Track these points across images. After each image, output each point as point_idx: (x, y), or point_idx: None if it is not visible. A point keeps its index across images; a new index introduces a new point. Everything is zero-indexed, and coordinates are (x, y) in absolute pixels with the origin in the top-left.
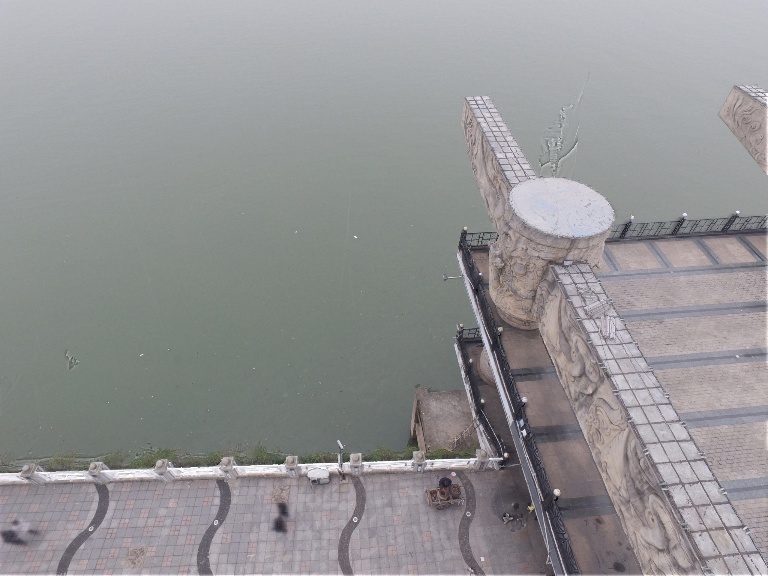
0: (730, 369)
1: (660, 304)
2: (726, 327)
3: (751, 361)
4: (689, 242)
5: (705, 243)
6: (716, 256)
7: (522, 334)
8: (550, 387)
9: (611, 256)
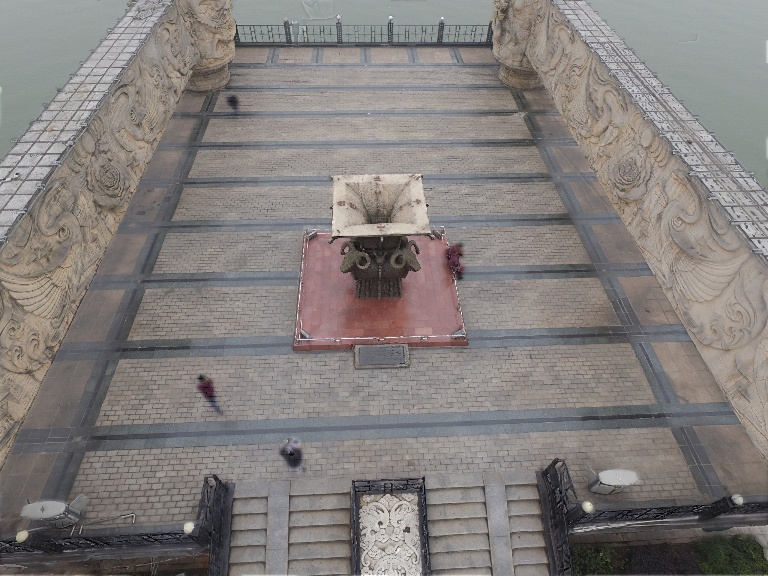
0: (354, 120)
1: (333, 83)
2: (378, 97)
3: (378, 117)
4: (402, 49)
5: (416, 50)
6: (417, 58)
7: (191, 94)
8: (184, 123)
9: (320, 54)
